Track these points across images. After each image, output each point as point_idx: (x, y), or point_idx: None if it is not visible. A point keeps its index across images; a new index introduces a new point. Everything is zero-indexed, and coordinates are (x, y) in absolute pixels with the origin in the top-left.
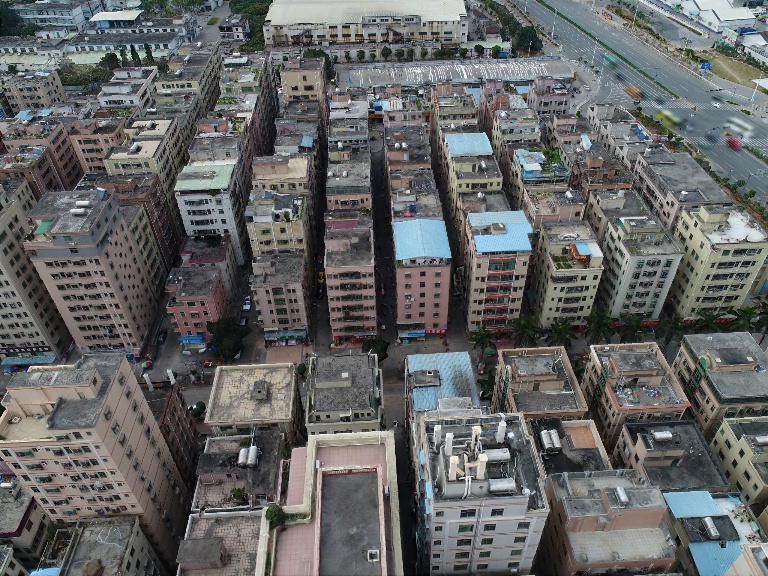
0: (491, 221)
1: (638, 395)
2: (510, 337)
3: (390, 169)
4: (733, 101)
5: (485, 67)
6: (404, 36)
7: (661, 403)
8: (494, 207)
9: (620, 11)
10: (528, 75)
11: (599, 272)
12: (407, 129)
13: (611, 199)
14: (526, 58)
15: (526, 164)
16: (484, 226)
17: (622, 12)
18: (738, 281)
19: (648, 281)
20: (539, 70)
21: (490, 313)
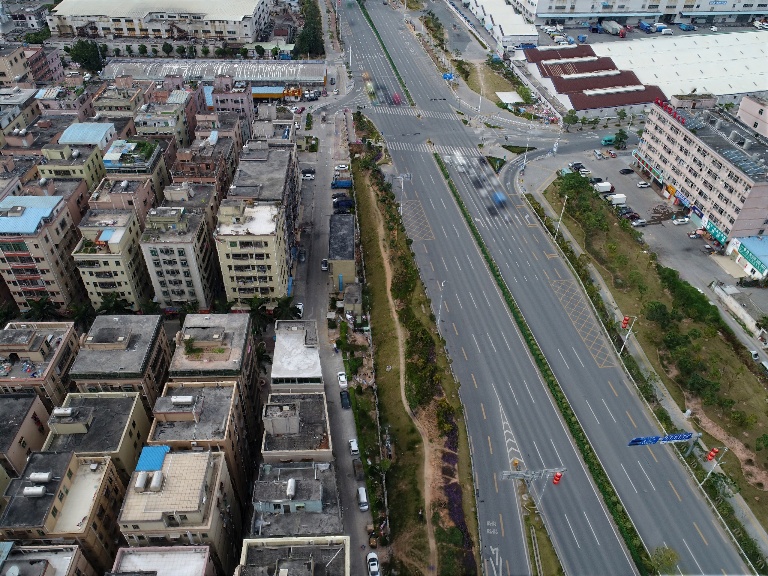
0: (19, 204)
1: (13, 369)
2: (71, 320)
3: (3, 154)
4: (463, 111)
5: (243, 67)
6: (188, 33)
7: (27, 377)
8: (63, 193)
9: (428, 22)
10: (280, 76)
11: (118, 258)
12: (62, 118)
13: (173, 190)
14: (291, 60)
15: (108, 154)
16: (8, 209)
17: (430, 23)
18: (262, 273)
19: (172, 269)
20: (293, 72)
21: (31, 295)
